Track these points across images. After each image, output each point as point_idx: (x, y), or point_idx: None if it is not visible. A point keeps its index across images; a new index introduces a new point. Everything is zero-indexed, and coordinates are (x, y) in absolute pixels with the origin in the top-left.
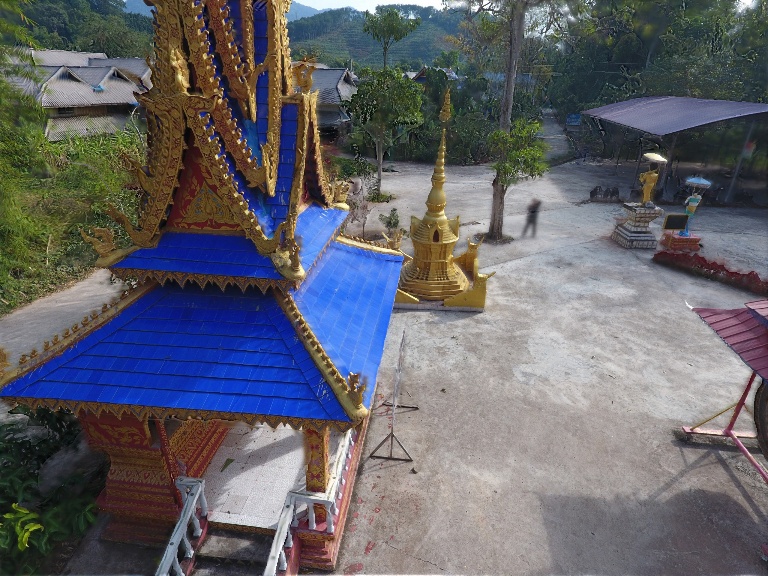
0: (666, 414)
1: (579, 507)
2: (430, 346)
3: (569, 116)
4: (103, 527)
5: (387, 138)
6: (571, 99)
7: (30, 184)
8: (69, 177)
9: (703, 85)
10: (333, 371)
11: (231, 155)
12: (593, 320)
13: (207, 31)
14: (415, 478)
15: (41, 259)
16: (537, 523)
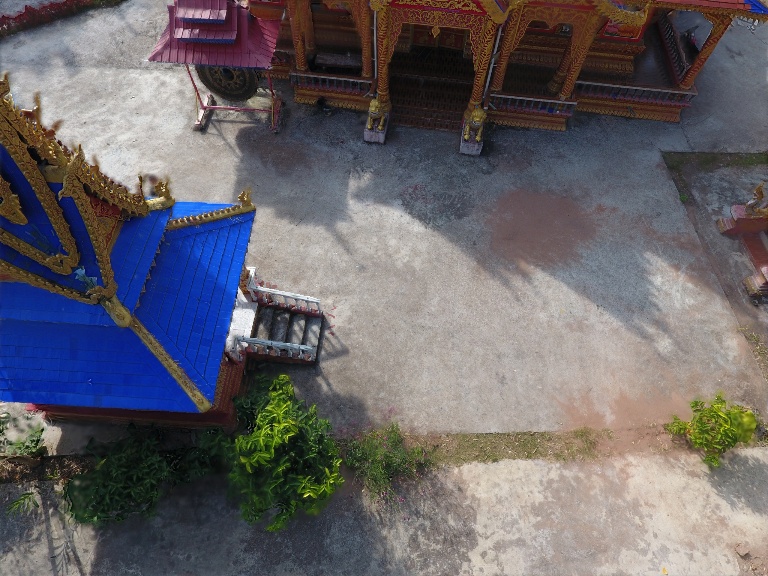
0: (179, 128)
1: (242, 187)
2: None
3: None
4: None
5: None
6: None
7: None
8: None
9: None
10: (228, 210)
11: None
12: None
13: None
14: None
15: None
16: None
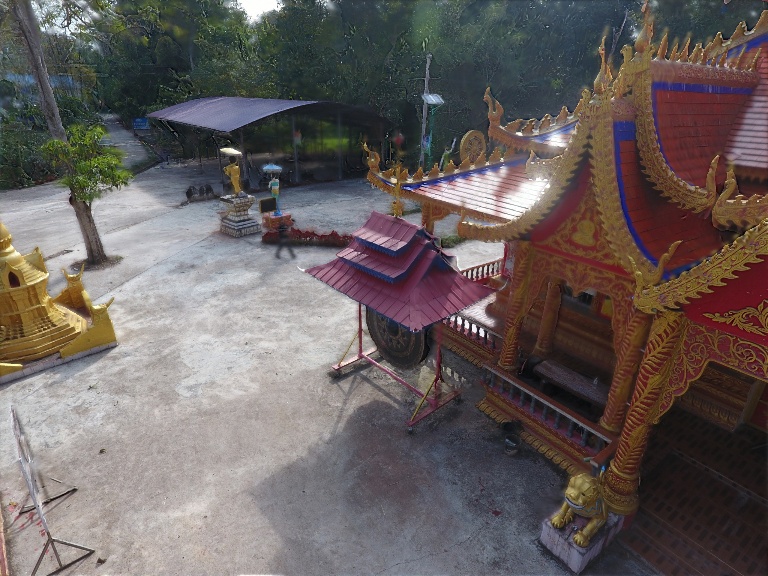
0: (318, 363)
1: (285, 478)
2: (62, 411)
3: (134, 120)
4: None
5: None
6: (129, 103)
7: None
8: None
9: (246, 86)
10: None
11: None
12: (234, 310)
13: None
14: (106, 568)
15: None
16: (256, 517)
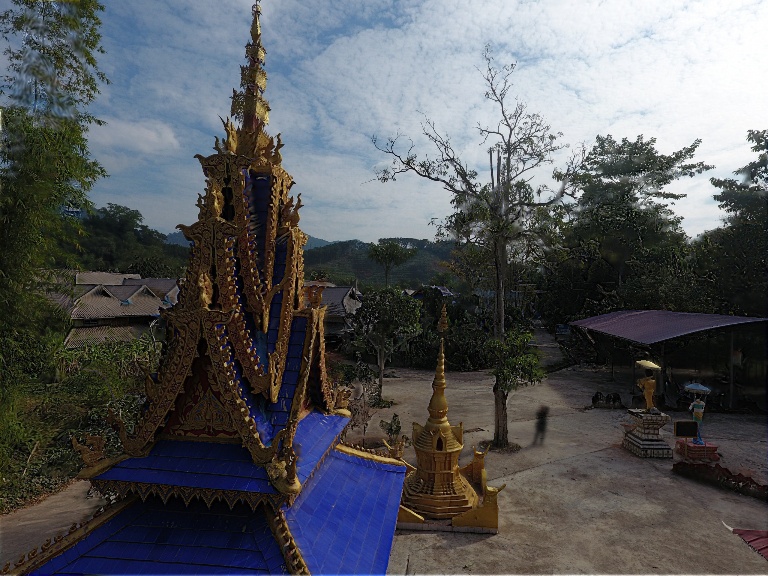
0: None
1: None
2: None
3: (558, 326)
4: None
5: (388, 346)
6: (557, 312)
7: (34, 389)
8: (75, 382)
9: (675, 300)
10: None
11: (239, 363)
12: (623, 545)
13: (234, 259)
14: None
15: (19, 469)
16: None
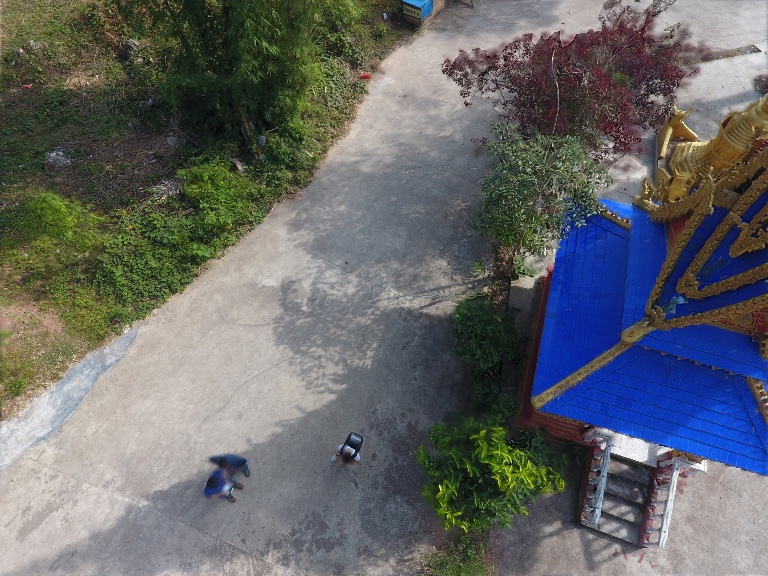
0: None
1: None
2: None
3: None
4: (511, 423)
5: None
6: None
7: None
8: None
9: None
10: None
11: None
12: None
13: None
14: None
15: None
16: None
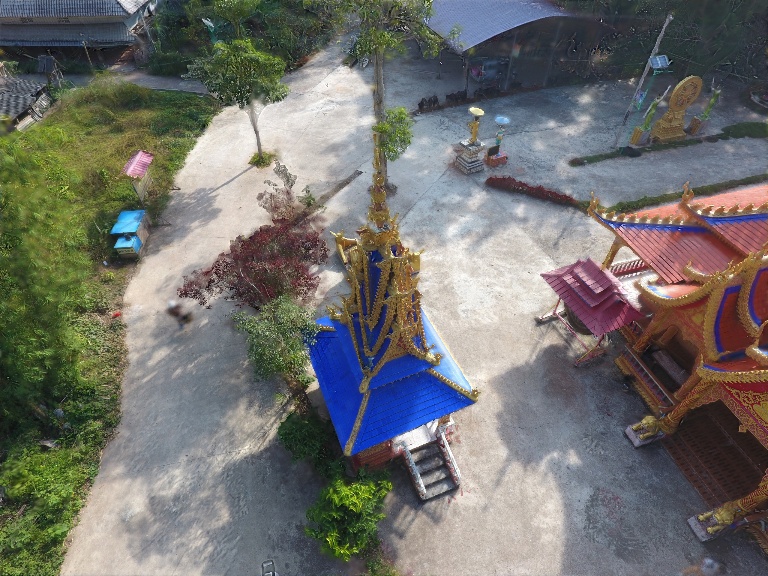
0: (529, 310)
1: (516, 374)
2: None
3: None
4: None
5: (258, 108)
6: None
7: None
8: None
9: None
10: (462, 389)
11: None
12: (477, 256)
13: None
14: None
15: None
16: (505, 388)
